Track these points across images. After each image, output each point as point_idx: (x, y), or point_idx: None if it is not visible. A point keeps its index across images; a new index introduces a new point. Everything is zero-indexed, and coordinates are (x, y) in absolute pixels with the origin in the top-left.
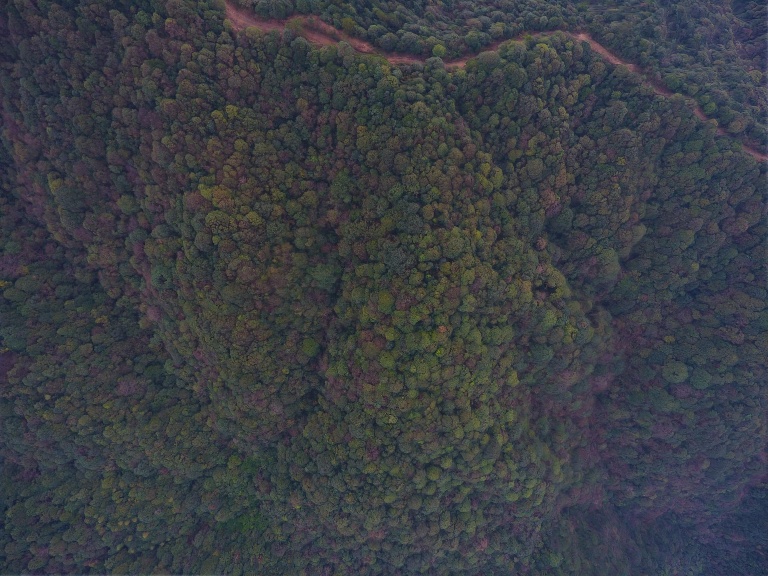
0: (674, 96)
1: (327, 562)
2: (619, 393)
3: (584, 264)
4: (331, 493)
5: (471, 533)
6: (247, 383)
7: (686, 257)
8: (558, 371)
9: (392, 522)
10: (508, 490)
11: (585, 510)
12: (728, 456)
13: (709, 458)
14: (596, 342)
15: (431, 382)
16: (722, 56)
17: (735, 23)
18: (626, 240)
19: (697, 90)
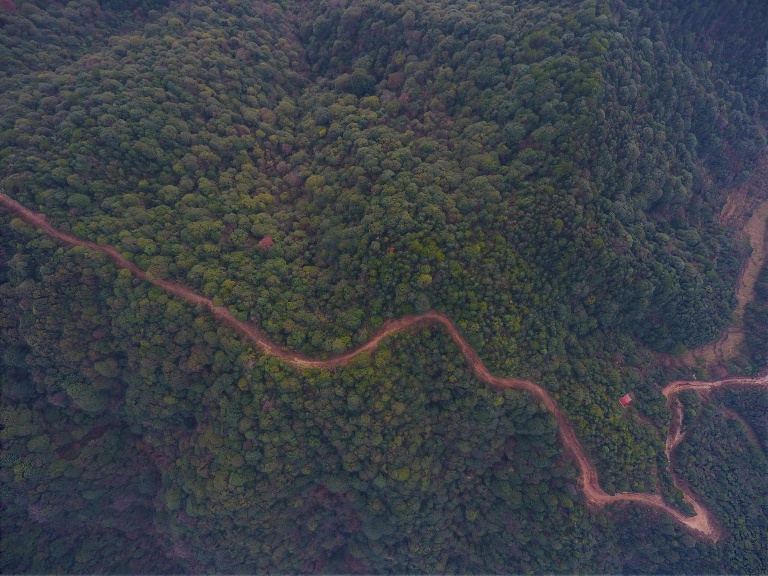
0: (72, 250)
1: None
2: None
3: (53, 399)
4: None
5: None
6: None
7: (155, 391)
8: None
9: None
10: None
11: None
12: (258, 573)
13: None
14: (69, 475)
15: None
16: (219, 183)
17: (269, 140)
18: (90, 376)
19: (103, 241)
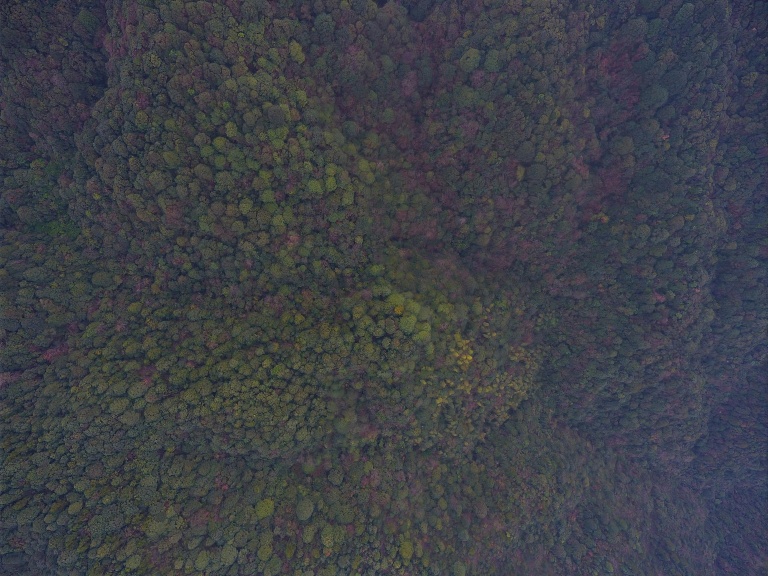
0: None
1: (145, 273)
2: (434, 108)
3: None
4: (115, 160)
5: (278, 226)
6: (10, 32)
7: None
8: (344, 48)
9: (178, 187)
10: (306, 174)
11: (422, 247)
12: (538, 157)
13: (524, 166)
14: (381, 19)
15: (188, 17)
16: None
17: None
18: None
19: None
